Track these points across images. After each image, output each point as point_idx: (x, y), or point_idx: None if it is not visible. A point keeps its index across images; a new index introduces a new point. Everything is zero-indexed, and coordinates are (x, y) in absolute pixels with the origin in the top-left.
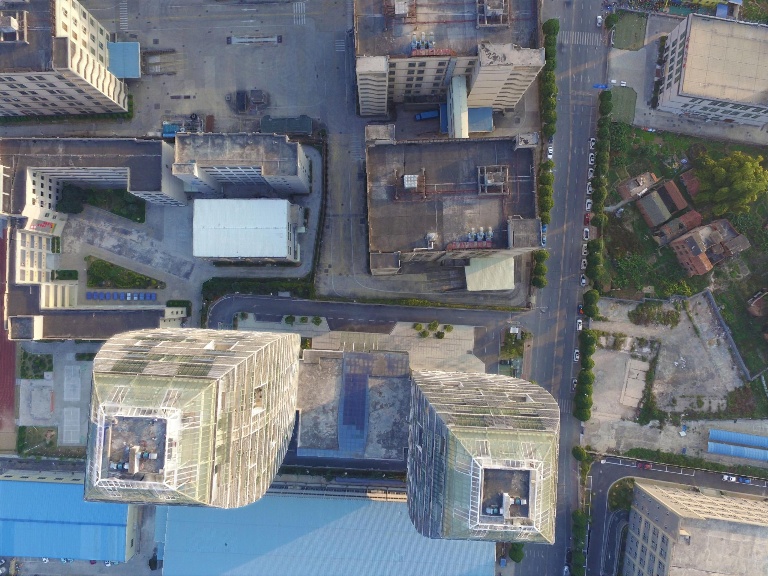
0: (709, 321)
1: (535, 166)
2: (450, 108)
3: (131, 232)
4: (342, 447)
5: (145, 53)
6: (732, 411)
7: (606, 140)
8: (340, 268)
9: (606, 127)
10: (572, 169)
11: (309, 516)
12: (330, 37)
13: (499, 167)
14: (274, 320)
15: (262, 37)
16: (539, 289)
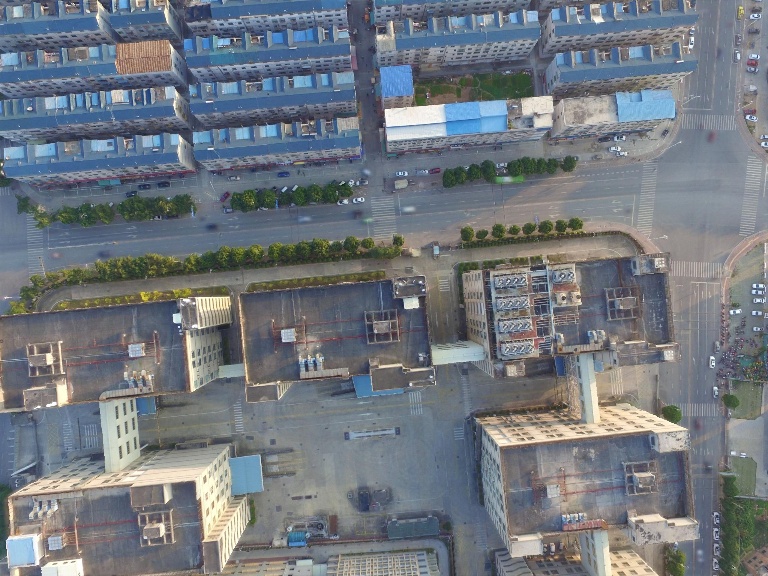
0: None
1: None
2: None
3: None
4: None
5: (262, 454)
6: None
7: (735, 530)
8: None
9: (733, 514)
10: (697, 544)
11: None
12: (448, 425)
13: None
14: None
15: (380, 430)
16: None
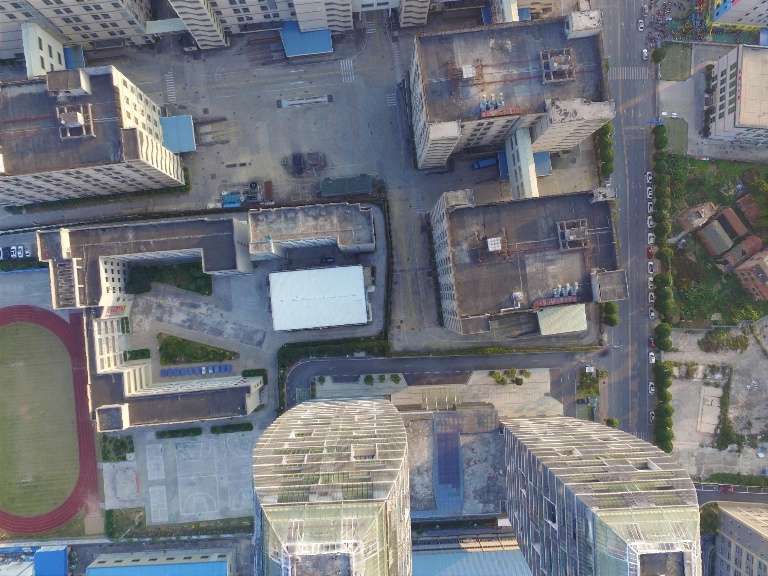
0: None
1: (614, 218)
2: (513, 158)
3: (199, 305)
4: (440, 506)
5: (196, 123)
6: None
7: (665, 175)
8: (412, 323)
9: (664, 162)
10: (631, 204)
11: None
12: (380, 92)
13: (578, 221)
14: (351, 381)
15: (312, 98)
16: (609, 326)
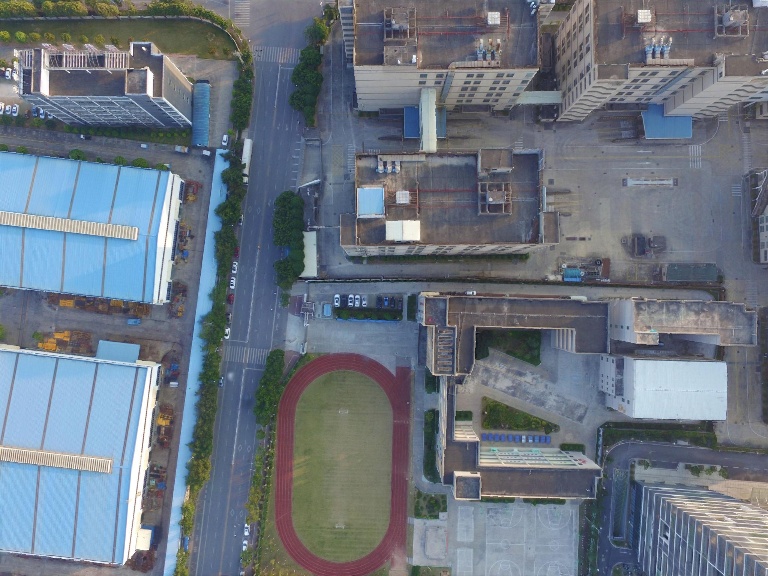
0: None
1: None
2: None
3: (525, 374)
4: None
5: None
6: None
7: None
8: (736, 416)
9: None
10: None
11: None
12: (726, 181)
13: None
14: (669, 467)
15: (658, 180)
16: None
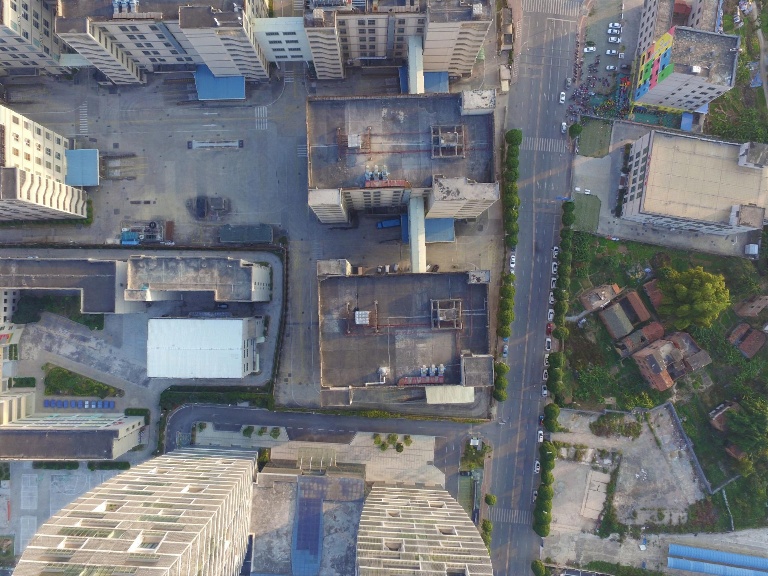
0: (671, 433)
1: None
2: (409, 224)
3: (89, 339)
4: (295, 572)
5: (105, 157)
6: (693, 524)
7: (568, 254)
8: (300, 377)
9: (568, 240)
10: (535, 278)
11: None
12: (292, 142)
13: (452, 301)
14: (233, 429)
15: (223, 142)
16: None
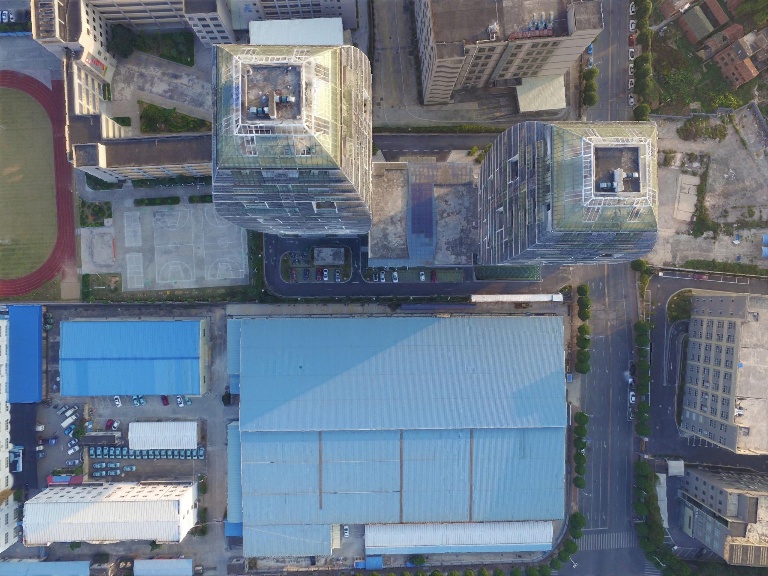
0: (755, 133)
1: None
2: None
3: (181, 76)
4: (412, 255)
5: None
6: None
7: None
8: (392, 100)
9: None
10: None
11: (380, 336)
12: None
13: None
14: None
15: None
16: (588, 111)
